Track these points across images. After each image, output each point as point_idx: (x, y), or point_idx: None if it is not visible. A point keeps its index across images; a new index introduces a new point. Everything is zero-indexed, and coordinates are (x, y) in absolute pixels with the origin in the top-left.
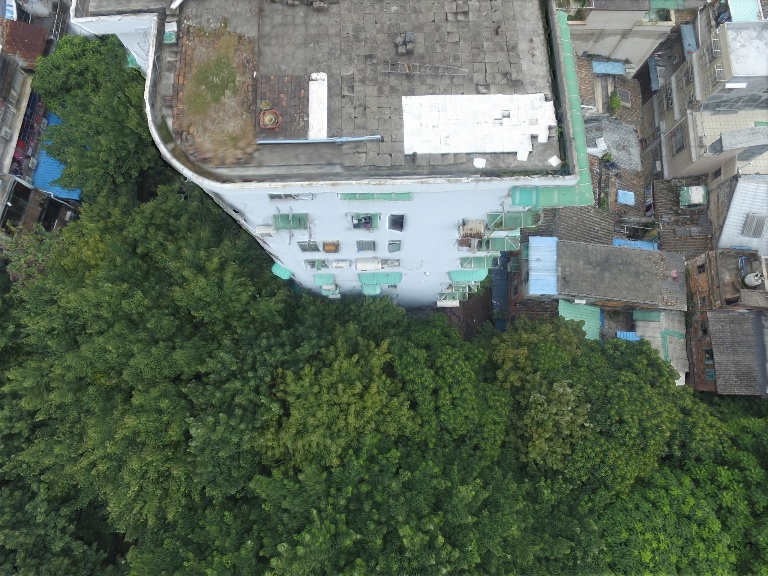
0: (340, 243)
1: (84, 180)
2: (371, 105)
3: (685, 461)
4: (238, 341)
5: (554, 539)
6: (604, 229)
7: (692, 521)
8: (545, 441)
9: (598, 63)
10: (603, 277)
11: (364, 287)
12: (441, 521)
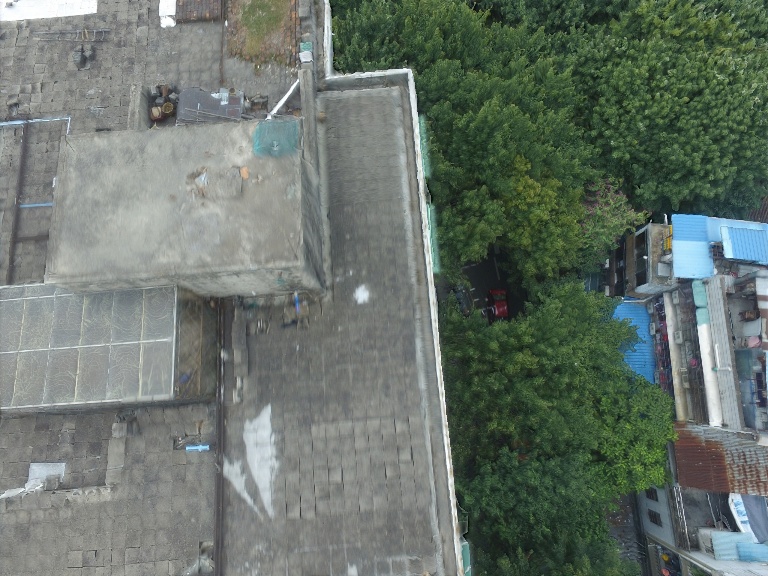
0: None
1: None
2: (124, 3)
3: None
4: None
5: None
6: None
7: None
8: None
9: None
10: None
11: None
12: None
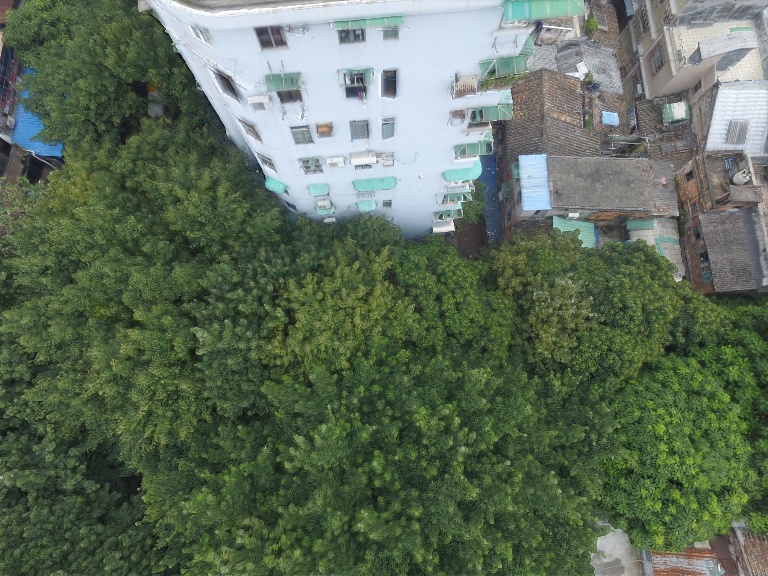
0: (333, 125)
1: (65, 132)
2: None
3: (689, 348)
4: (237, 260)
5: (568, 426)
6: (591, 148)
7: (701, 396)
8: None
9: None
10: (595, 188)
11: (359, 204)
12: (456, 410)
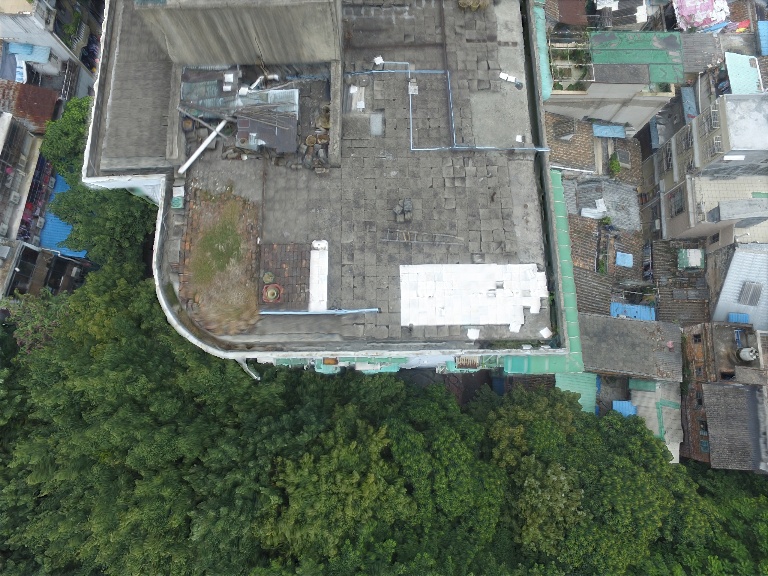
0: None
1: (90, 243)
2: (370, 274)
3: (677, 545)
4: (239, 424)
5: None
6: (602, 293)
7: None
8: (539, 524)
9: (599, 126)
10: (600, 348)
11: None
12: None
